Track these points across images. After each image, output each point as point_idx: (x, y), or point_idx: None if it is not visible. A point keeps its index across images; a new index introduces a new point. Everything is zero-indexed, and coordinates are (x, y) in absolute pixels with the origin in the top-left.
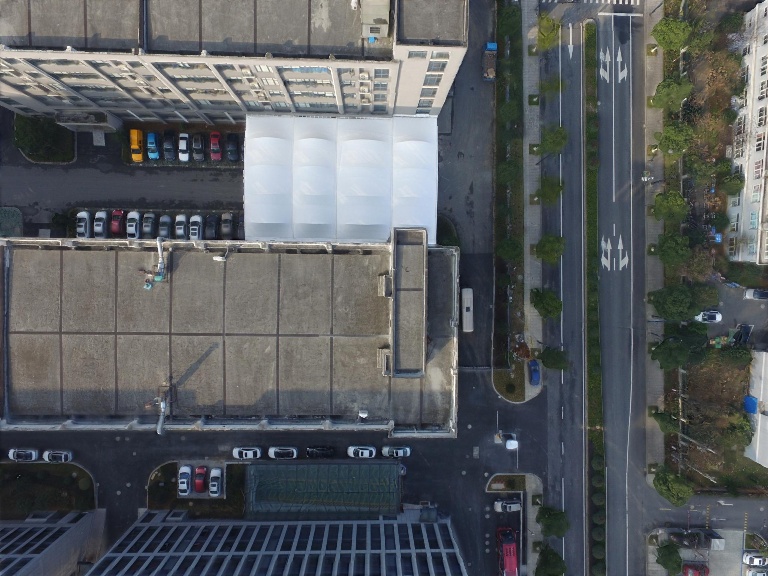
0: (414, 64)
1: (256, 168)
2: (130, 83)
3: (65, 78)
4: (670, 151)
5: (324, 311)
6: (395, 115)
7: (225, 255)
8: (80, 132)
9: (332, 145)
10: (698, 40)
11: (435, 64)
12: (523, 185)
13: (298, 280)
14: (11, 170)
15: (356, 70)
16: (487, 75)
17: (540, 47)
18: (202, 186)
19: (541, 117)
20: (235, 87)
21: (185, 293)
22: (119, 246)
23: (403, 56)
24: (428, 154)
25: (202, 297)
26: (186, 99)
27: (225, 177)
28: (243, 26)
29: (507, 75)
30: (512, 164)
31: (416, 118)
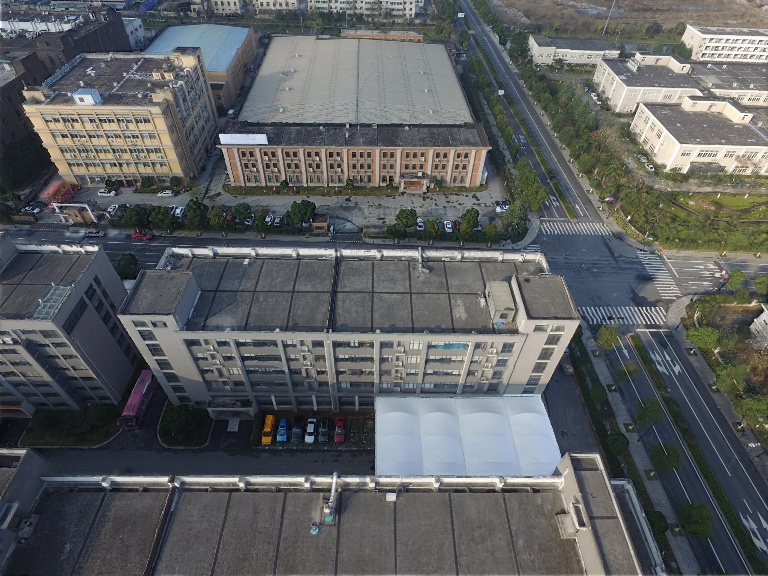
0: (536, 337)
1: (388, 438)
2: (298, 364)
3: (248, 361)
4: (760, 419)
5: (507, 558)
6: (504, 395)
7: (396, 494)
8: (218, 420)
9: (454, 419)
10: (727, 340)
11: (552, 337)
12: (633, 461)
13: (472, 521)
14: (143, 455)
15: (488, 345)
16: (567, 370)
17: (601, 352)
18: (323, 467)
19: (624, 402)
20: (382, 366)
21: (353, 538)
22: (288, 487)
23: (530, 330)
24: (543, 424)
25: (371, 543)
26: (334, 380)
27: (345, 458)
28: (403, 317)
29: (584, 369)
30: (620, 435)
31: (522, 397)
